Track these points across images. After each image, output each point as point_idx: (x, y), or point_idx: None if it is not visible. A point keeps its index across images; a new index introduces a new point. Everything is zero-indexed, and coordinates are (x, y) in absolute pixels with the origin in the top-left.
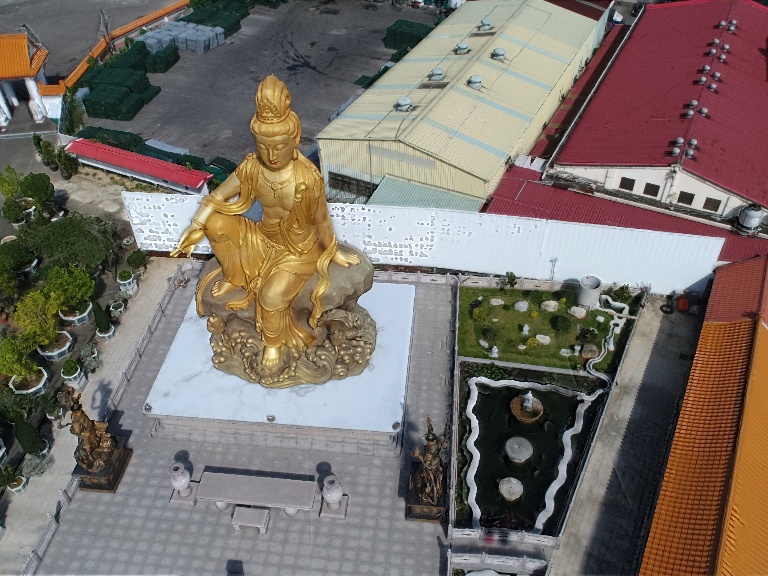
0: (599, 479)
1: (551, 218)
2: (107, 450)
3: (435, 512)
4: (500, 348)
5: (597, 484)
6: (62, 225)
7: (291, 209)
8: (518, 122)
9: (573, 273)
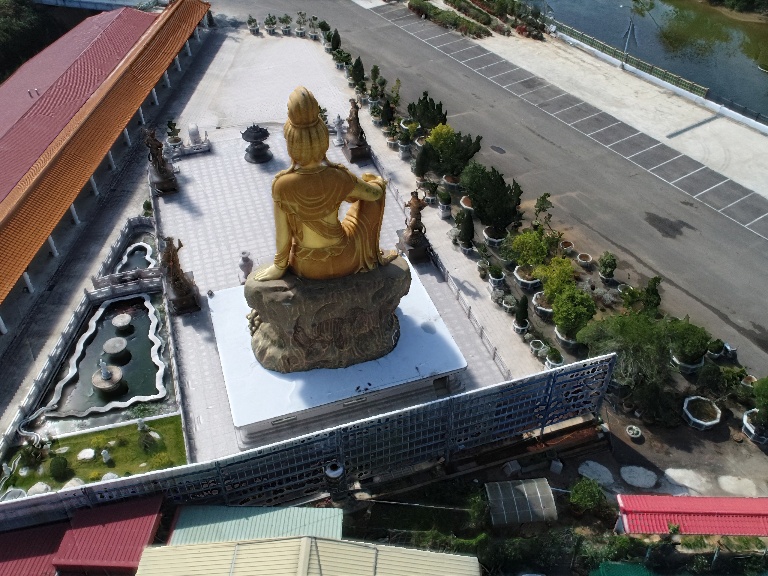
0: (50, 349)
1: (51, 575)
2: None
3: None
4: (137, 435)
5: (53, 345)
6: (643, 329)
7: None
8: None
9: None
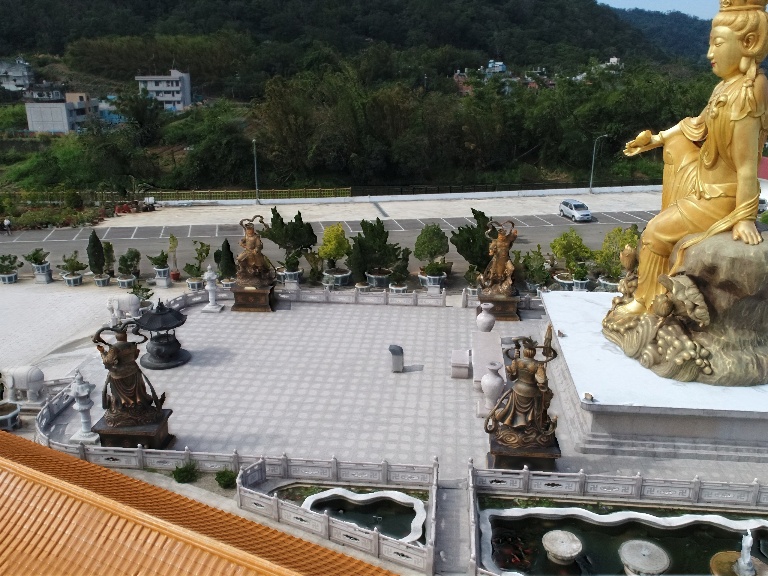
0: None
1: None
2: (502, 291)
3: None
4: None
5: None
6: None
7: None
8: None
9: None
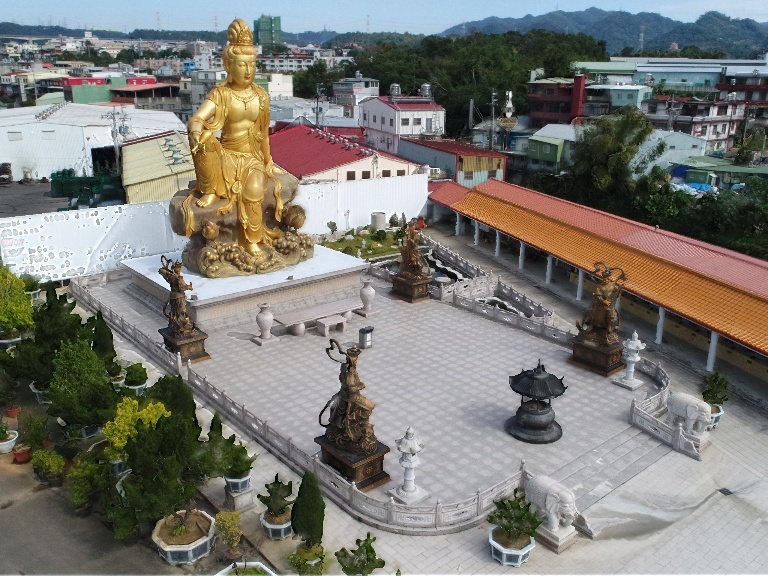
0: None
1: None
2: None
3: (425, 290)
4: None
5: None
6: None
7: (257, 118)
8: None
9: (359, 222)
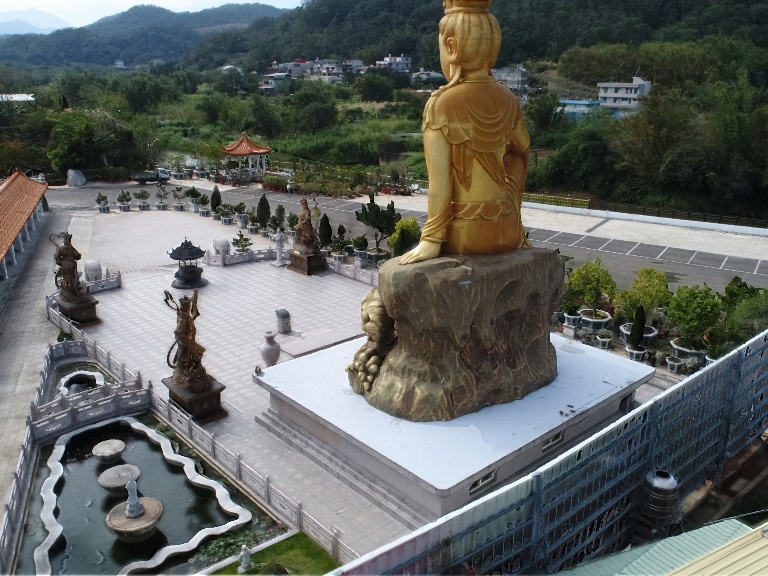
0: None
1: None
2: None
3: None
4: None
5: None
6: None
7: None
8: None
9: None
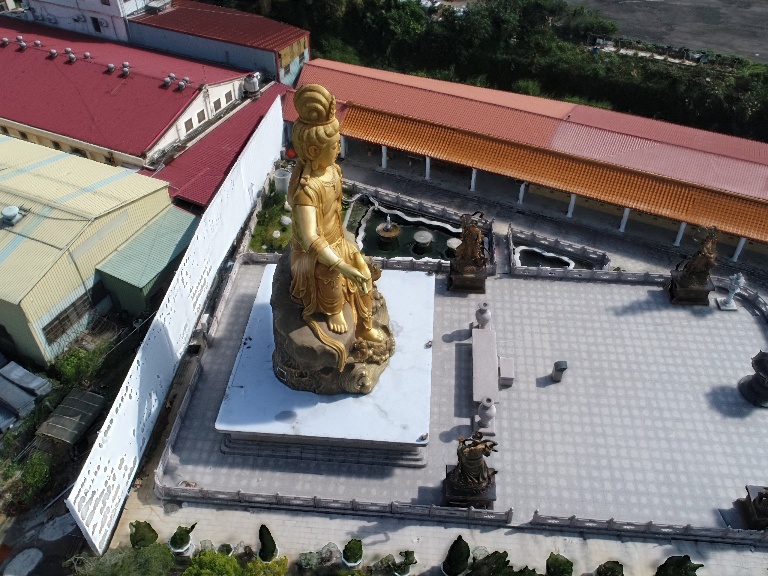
0: None
1: None
2: None
3: None
4: None
5: None
6: None
7: None
8: (71, 159)
9: None
